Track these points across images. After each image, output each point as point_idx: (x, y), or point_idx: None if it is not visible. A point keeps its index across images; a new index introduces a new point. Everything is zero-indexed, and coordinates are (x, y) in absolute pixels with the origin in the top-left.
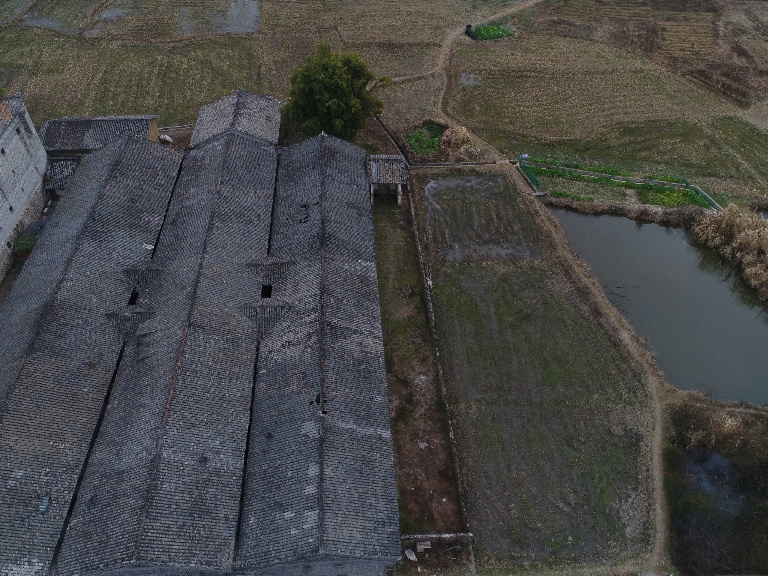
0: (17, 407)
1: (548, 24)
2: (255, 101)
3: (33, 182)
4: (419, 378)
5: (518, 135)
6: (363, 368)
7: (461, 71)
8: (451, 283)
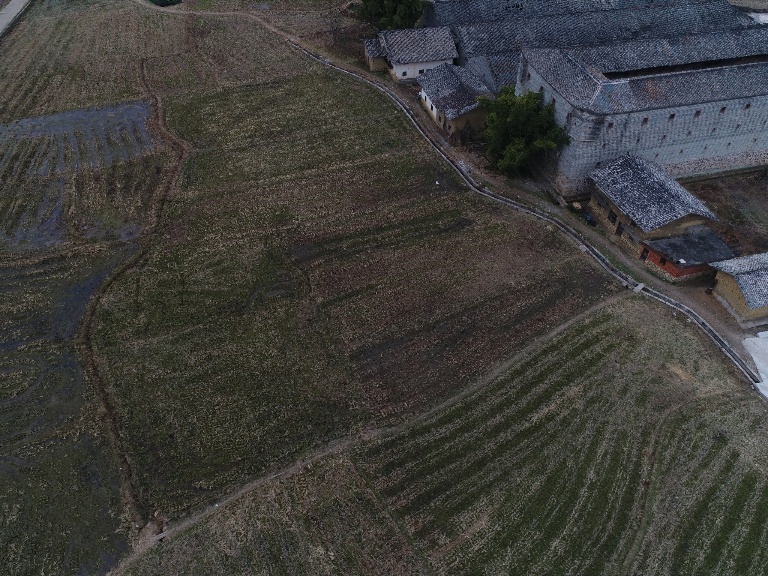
0: None
1: None
2: None
3: None
4: None
5: None
6: None
7: None
8: None
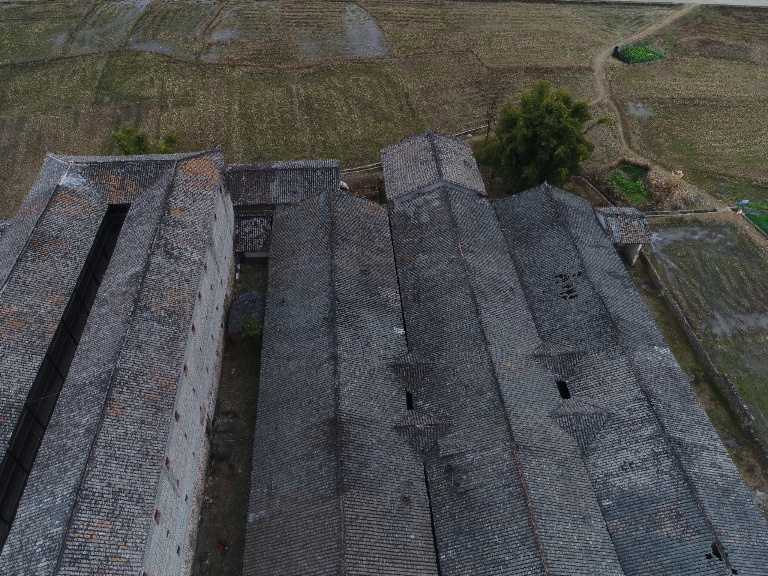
0: (358, 572)
1: (696, 44)
2: (447, 143)
3: (229, 246)
4: (756, 495)
5: (723, 176)
6: (734, 499)
7: (626, 99)
8: (734, 364)
